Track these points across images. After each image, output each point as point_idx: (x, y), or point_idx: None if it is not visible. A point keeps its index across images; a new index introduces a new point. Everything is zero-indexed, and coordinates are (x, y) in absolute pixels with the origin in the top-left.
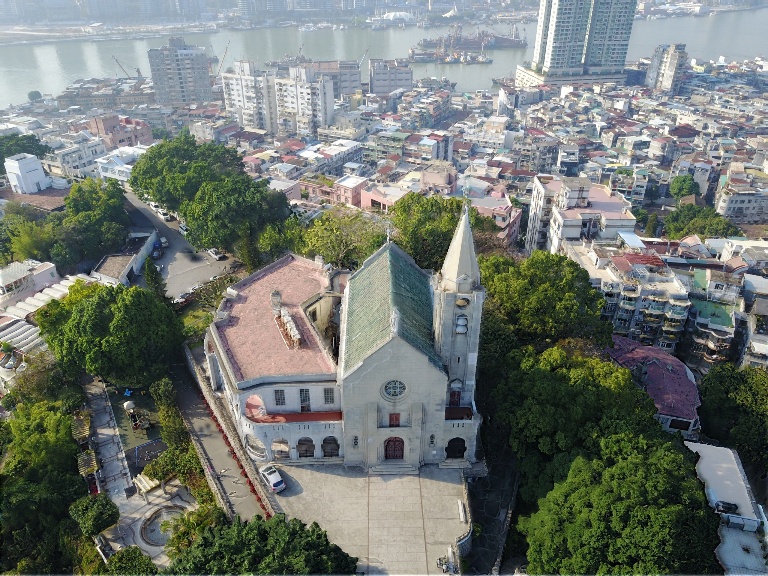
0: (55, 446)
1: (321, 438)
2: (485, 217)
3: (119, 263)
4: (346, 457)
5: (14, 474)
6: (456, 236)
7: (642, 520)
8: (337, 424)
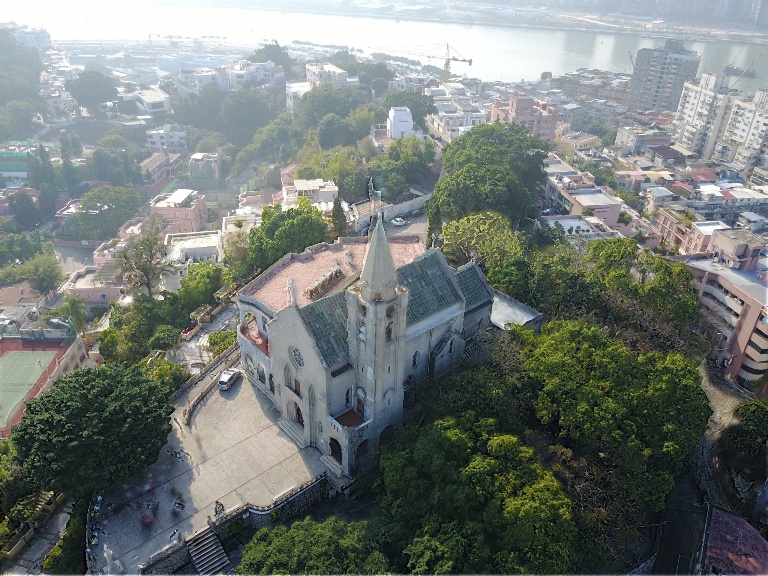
0: (193, 290)
1: (268, 372)
2: (684, 297)
3: (376, 205)
4: (276, 399)
5: None
6: None
7: None
8: None
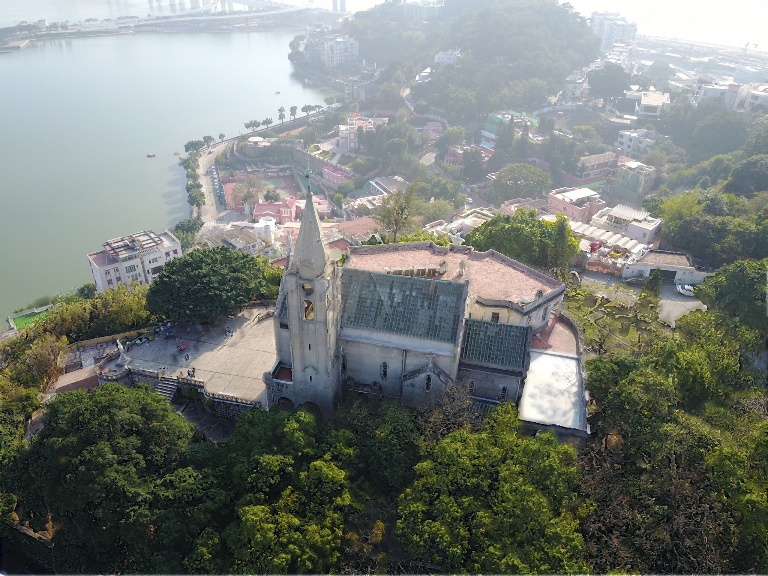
0: None
1: None
2: None
3: (673, 261)
4: None
5: None
6: None
7: None
8: None
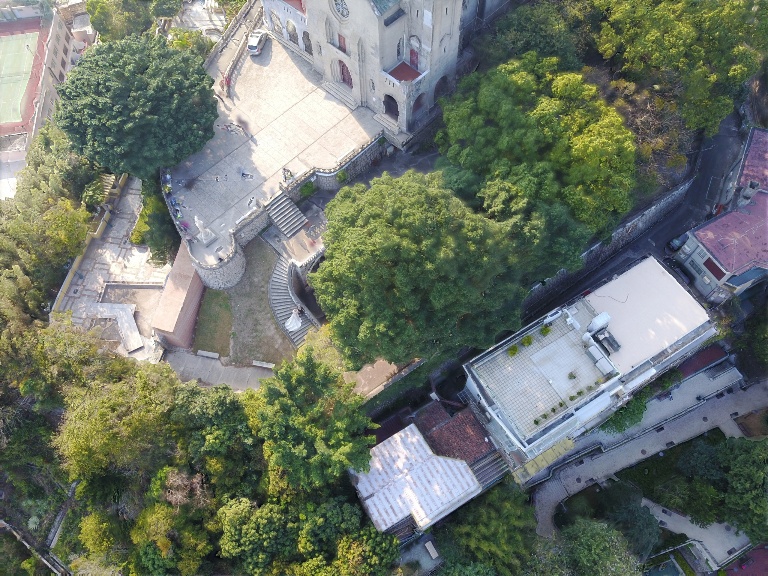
0: None
1: (300, 29)
2: None
3: None
4: (315, 60)
5: None
6: None
7: None
8: None
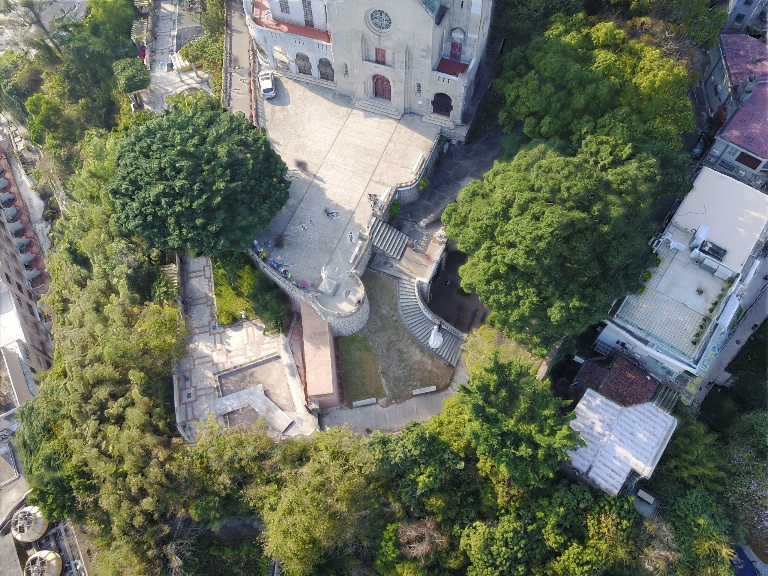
0: (113, 7)
1: (316, 58)
2: None
3: None
4: (338, 84)
5: (89, 26)
6: None
7: (536, 214)
8: (329, 46)
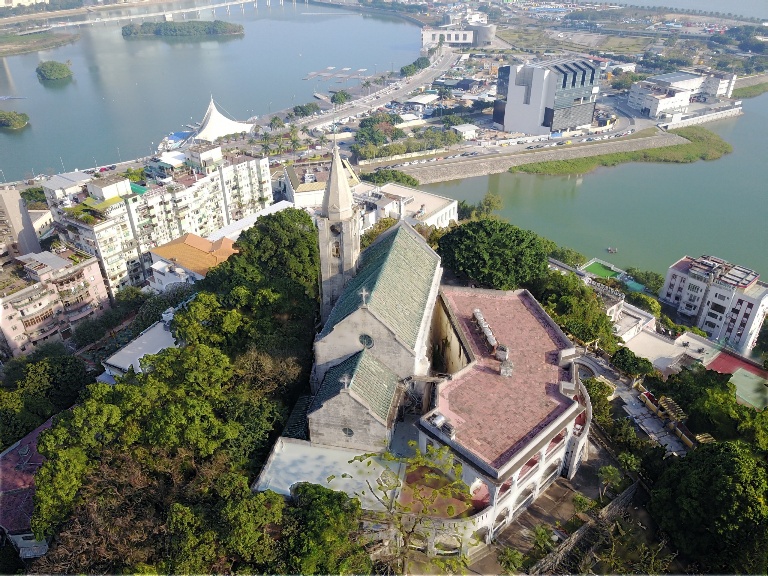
0: None
1: None
2: None
3: None
4: None
5: None
6: (340, 172)
7: None
8: None
